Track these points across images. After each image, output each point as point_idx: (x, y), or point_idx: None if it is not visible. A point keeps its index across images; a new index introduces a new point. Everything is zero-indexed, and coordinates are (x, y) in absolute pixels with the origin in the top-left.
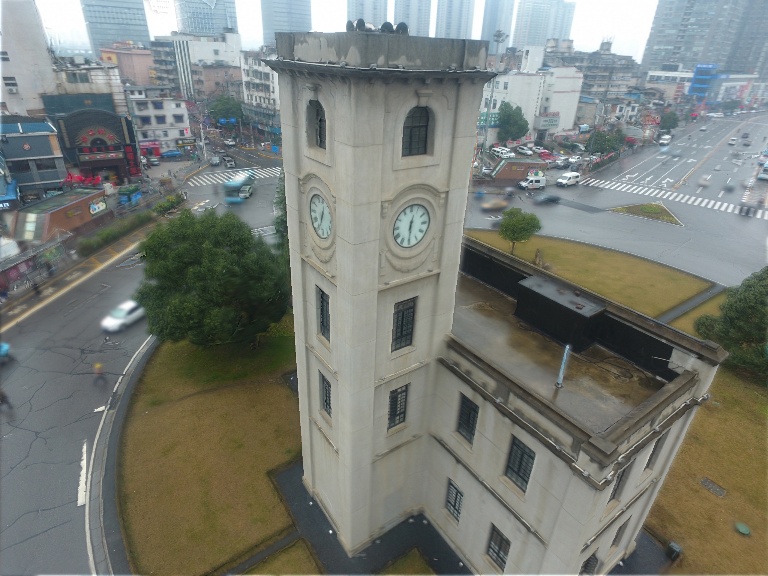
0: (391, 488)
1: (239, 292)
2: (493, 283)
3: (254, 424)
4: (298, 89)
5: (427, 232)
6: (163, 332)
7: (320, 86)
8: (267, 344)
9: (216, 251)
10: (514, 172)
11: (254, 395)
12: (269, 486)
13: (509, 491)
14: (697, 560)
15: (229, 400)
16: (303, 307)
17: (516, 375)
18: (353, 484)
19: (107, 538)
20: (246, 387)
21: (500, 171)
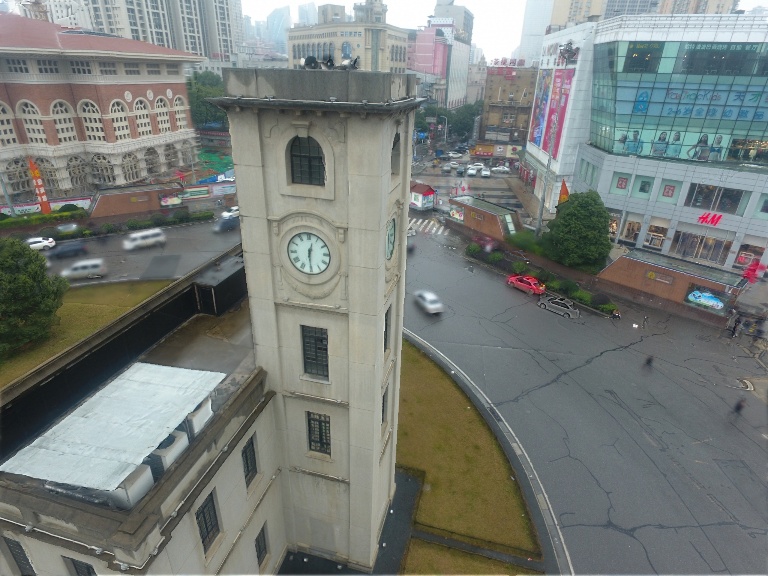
0: None
1: None
2: (161, 334)
3: None
4: None
5: None
6: None
7: None
8: None
9: None
10: None
11: None
12: None
13: None
14: None
15: None
16: (382, 357)
17: None
18: None
19: None
20: None
21: None
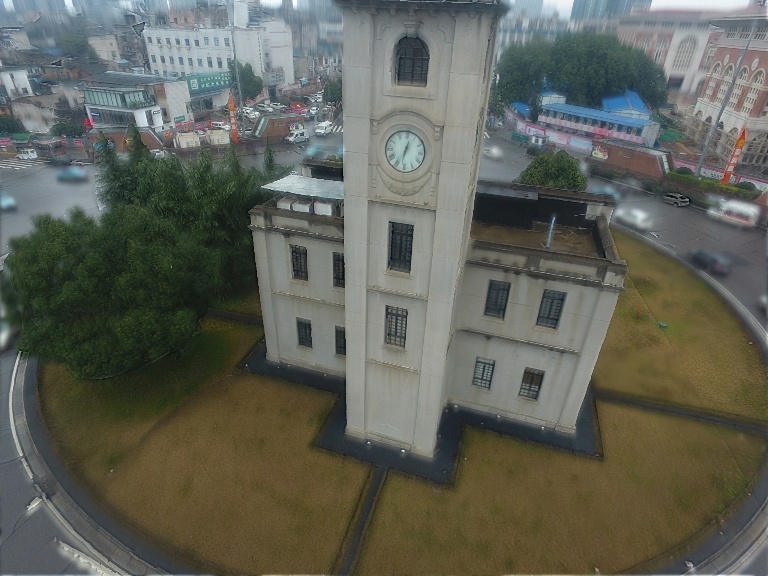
0: None
1: (182, 289)
2: None
3: (254, 416)
4: (375, 29)
5: (473, 151)
6: (101, 368)
7: (421, 23)
8: (188, 348)
9: (144, 248)
10: (277, 129)
11: (226, 395)
12: (322, 452)
13: (544, 333)
14: None
15: (204, 411)
16: (367, 250)
17: None
18: (440, 387)
19: None
20: (209, 393)
21: (264, 129)
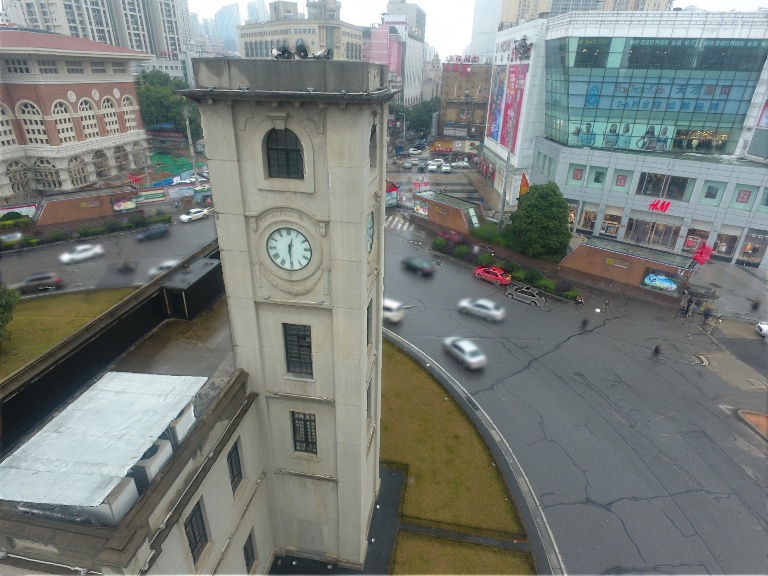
0: None
1: None
2: (131, 341)
3: None
4: None
5: None
6: None
7: None
8: None
9: None
10: None
11: None
12: None
13: None
14: None
15: None
16: None
17: None
18: None
19: None
20: None
21: None
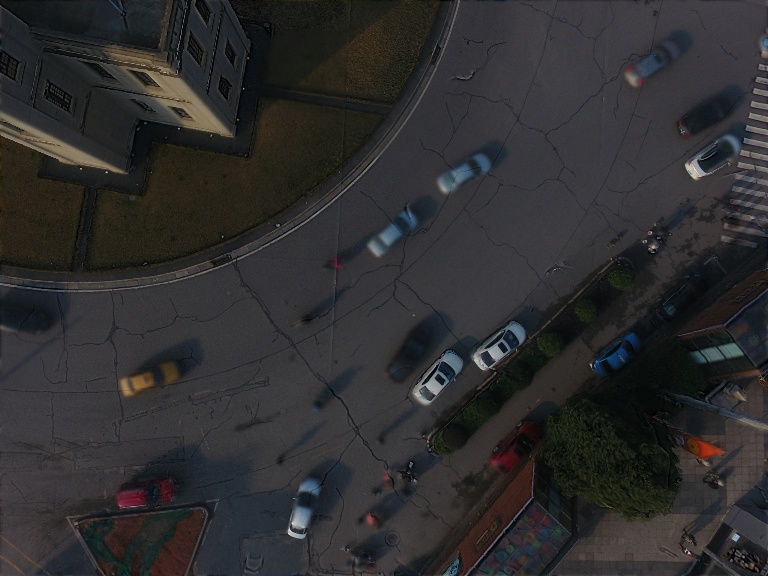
0: (108, 129)
1: None
2: None
3: None
4: None
5: None
6: None
7: None
8: None
9: None
10: None
11: None
12: (49, 182)
13: None
14: (281, 23)
15: None
16: None
17: (96, 26)
18: (86, 152)
19: (10, 276)
20: None
21: None
